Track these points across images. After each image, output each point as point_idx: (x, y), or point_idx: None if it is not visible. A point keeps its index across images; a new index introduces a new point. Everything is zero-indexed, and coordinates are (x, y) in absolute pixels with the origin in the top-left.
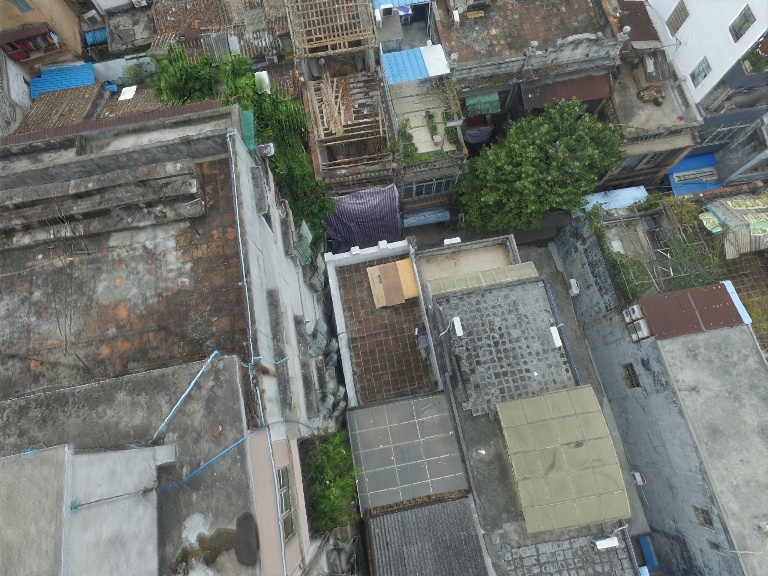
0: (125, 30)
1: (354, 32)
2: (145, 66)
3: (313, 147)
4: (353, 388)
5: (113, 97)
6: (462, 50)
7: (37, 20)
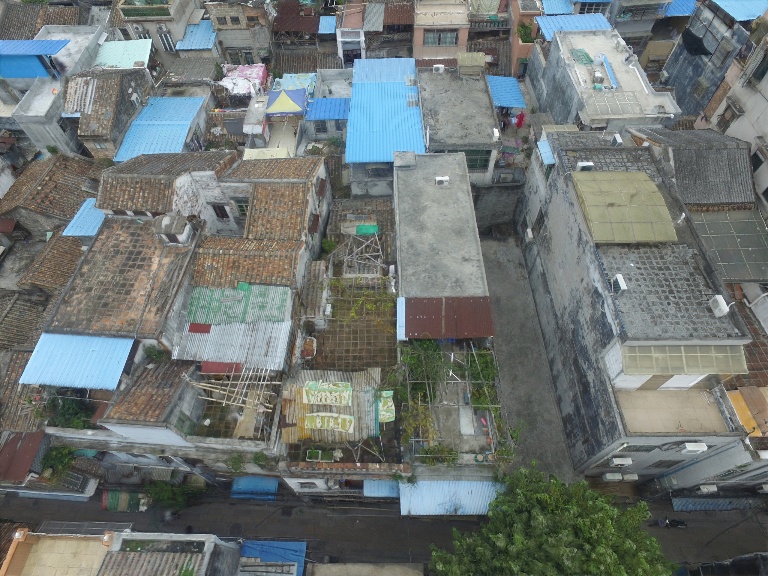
0: None
1: None
2: None
3: None
4: (765, 321)
5: None
6: None
7: None
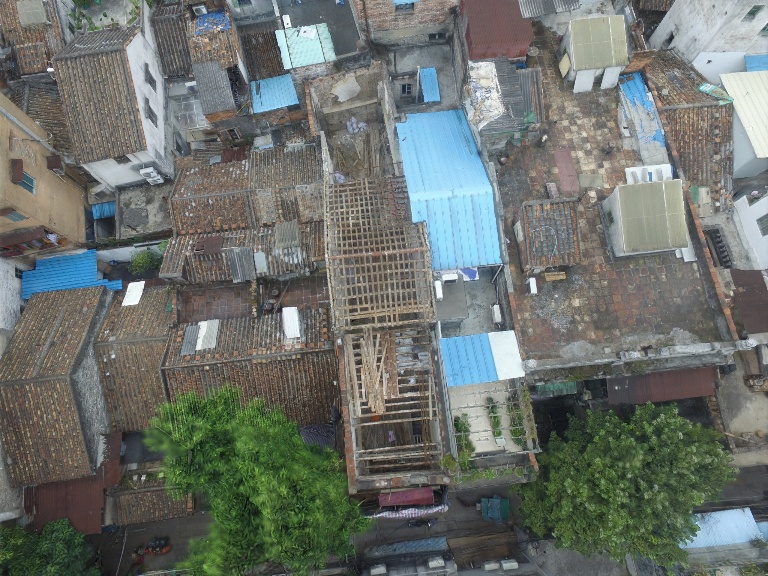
0: (137, 210)
1: (408, 303)
2: (156, 256)
3: (348, 444)
4: None
5: (117, 297)
6: (537, 326)
7: (33, 224)
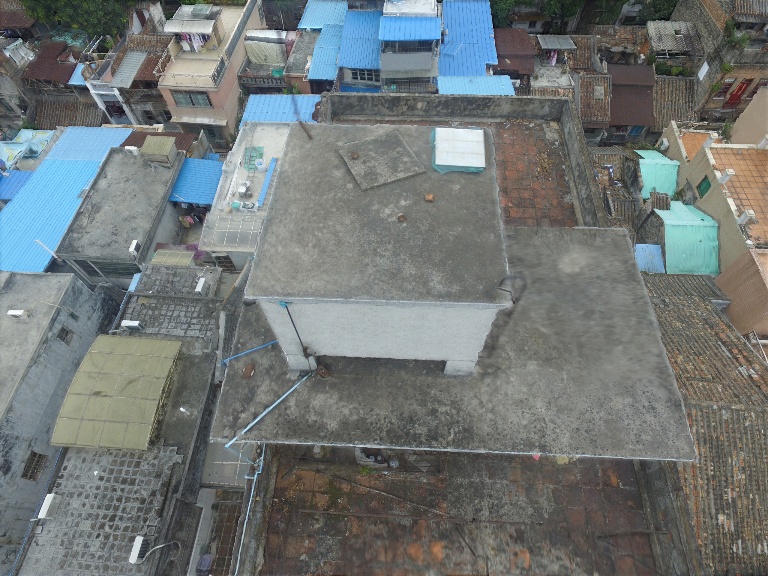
0: None
1: None
2: None
3: None
4: None
5: None
6: None
7: None
